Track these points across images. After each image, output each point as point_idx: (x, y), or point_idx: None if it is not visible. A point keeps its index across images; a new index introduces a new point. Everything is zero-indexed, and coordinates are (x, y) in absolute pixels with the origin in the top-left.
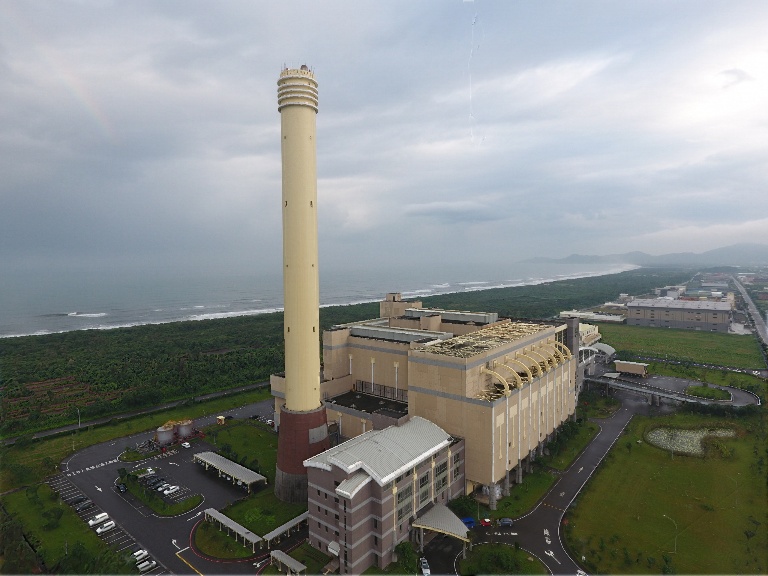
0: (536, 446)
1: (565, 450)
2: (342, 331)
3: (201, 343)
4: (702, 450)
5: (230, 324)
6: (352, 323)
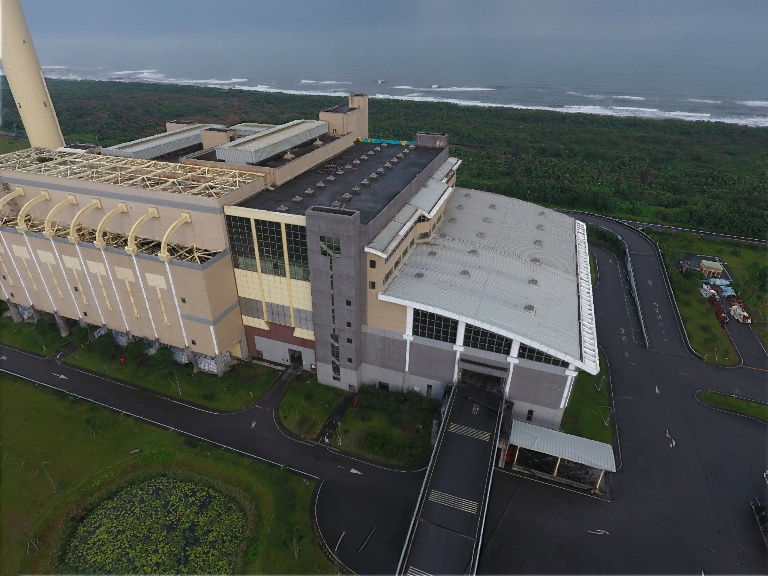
0: (77, 319)
1: (119, 362)
2: (179, 125)
3: (470, 135)
4: (95, 567)
5: (574, 123)
6: (267, 125)
